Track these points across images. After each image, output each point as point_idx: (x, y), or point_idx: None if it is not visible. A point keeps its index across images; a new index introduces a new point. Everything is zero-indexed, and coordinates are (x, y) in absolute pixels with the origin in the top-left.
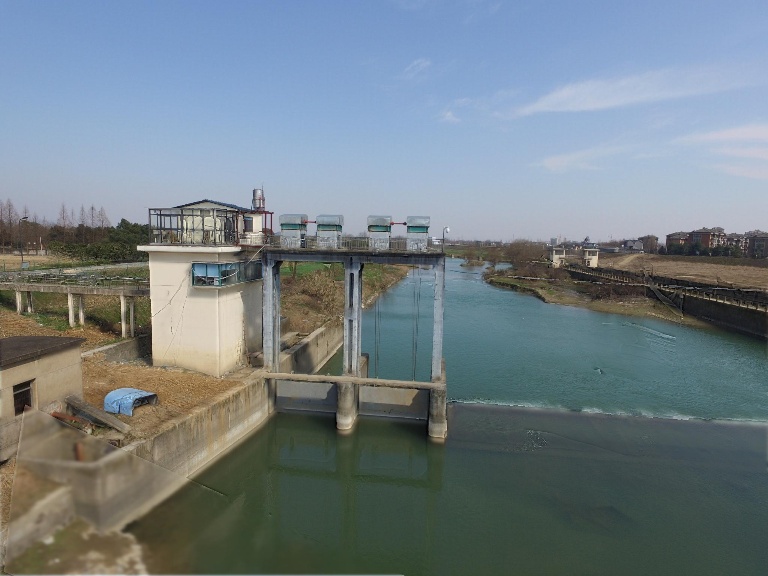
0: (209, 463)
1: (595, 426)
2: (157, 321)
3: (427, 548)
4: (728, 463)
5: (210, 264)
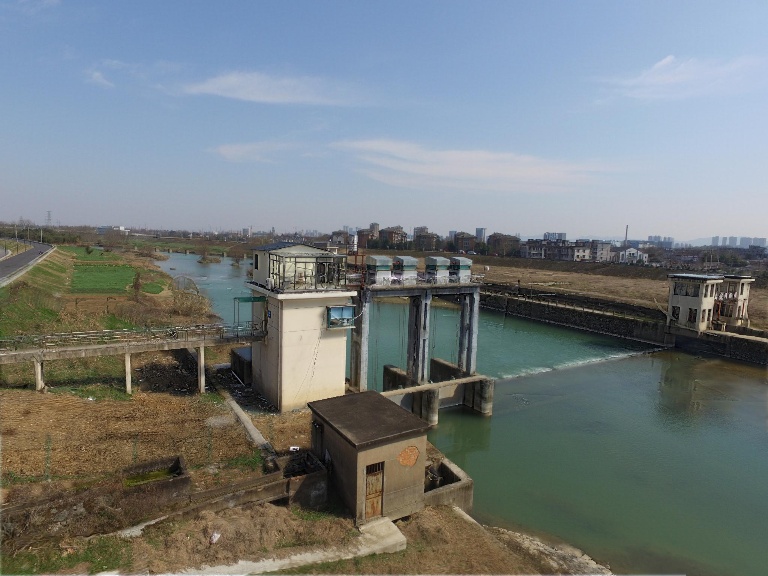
0: None
1: (528, 384)
2: (288, 367)
3: None
4: (595, 388)
5: (346, 307)
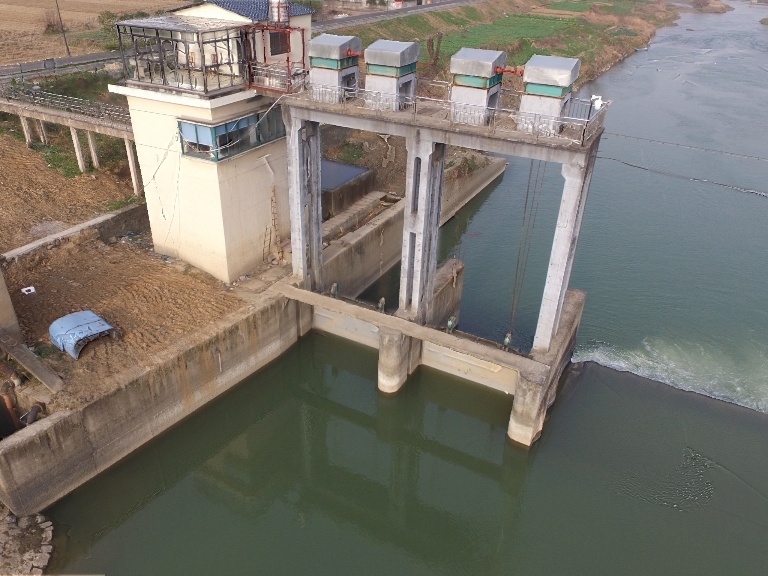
0: (189, 417)
1: None
2: (151, 195)
3: (498, 546)
4: None
5: (200, 125)
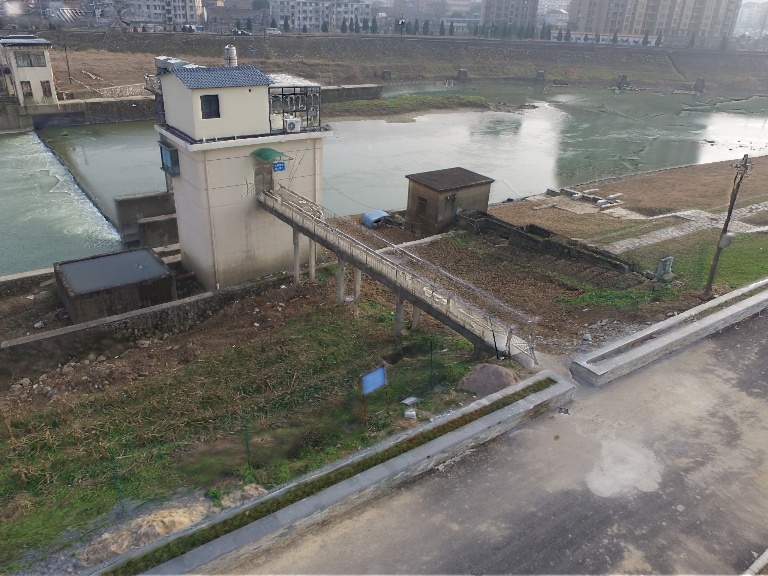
0: None
1: None
2: None
3: None
4: (147, 179)
5: None
